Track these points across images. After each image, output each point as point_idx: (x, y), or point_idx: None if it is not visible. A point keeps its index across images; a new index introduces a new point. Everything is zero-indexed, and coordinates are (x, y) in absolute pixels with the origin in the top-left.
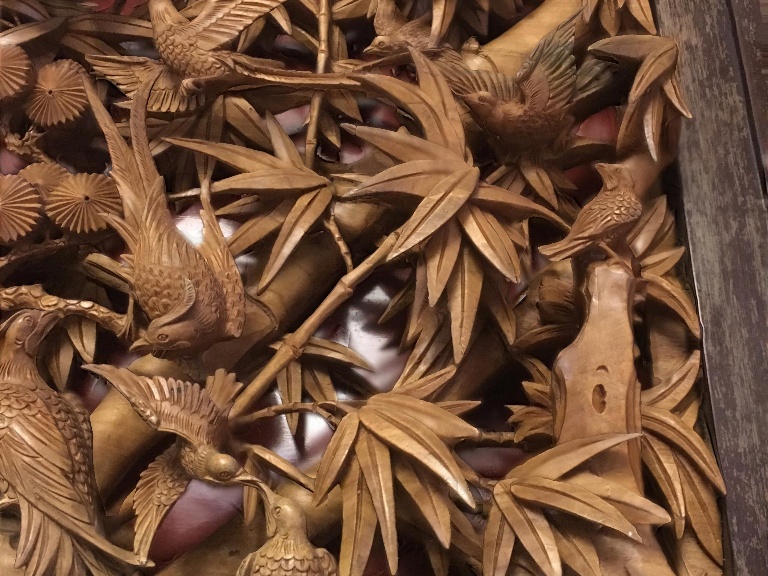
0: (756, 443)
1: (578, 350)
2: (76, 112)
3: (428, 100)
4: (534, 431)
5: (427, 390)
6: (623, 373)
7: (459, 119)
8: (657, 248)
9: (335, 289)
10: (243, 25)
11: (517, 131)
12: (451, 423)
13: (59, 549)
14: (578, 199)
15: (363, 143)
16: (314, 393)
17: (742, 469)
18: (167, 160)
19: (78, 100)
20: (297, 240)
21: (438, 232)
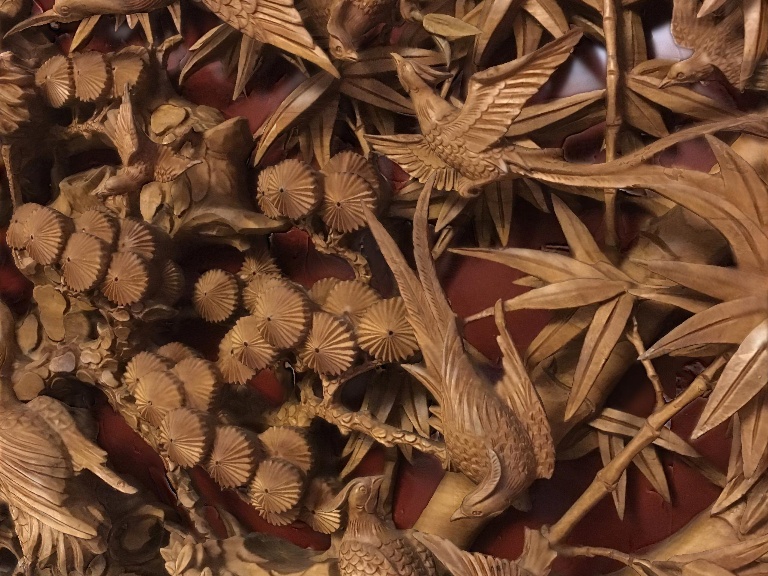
0: None
1: None
2: None
3: (734, 213)
4: None
5: (747, 559)
6: None
7: None
8: None
9: (642, 431)
10: (510, 117)
11: None
12: None
13: None
14: None
15: (674, 157)
16: (640, 466)
17: None
18: (463, 216)
19: None
20: (598, 369)
21: None
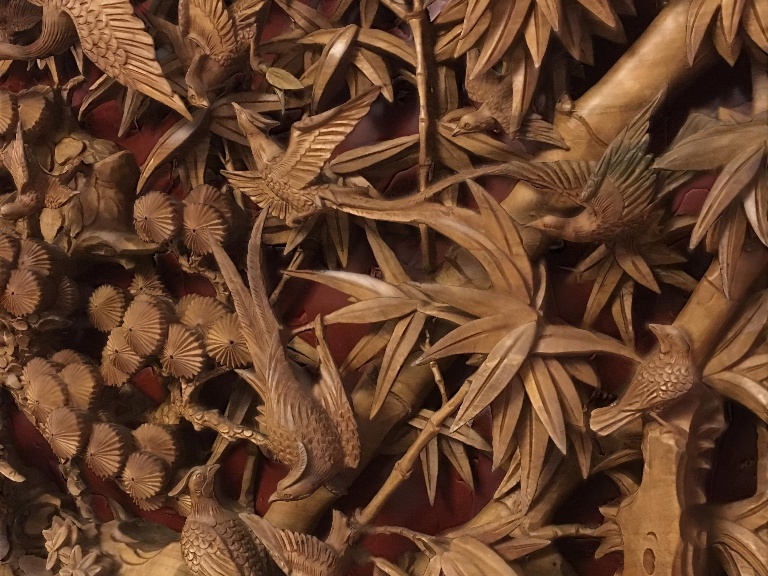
0: None
1: (632, 512)
2: None
3: (487, 245)
4: (614, 549)
5: (500, 534)
6: (670, 544)
7: (524, 253)
8: (763, 344)
9: (426, 427)
10: (323, 160)
11: (596, 240)
12: None
13: None
14: (689, 270)
15: None
16: (451, 459)
17: None
18: (310, 241)
19: (216, 233)
20: (394, 375)
21: (496, 398)
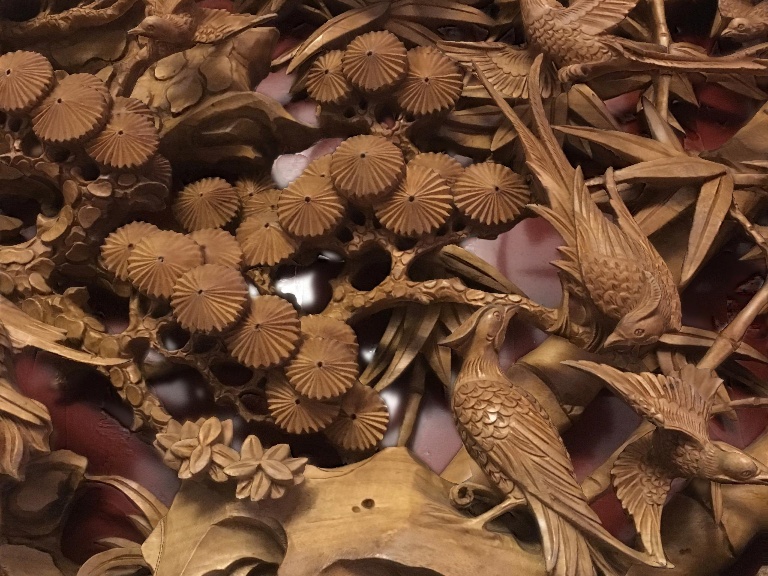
0: None
1: None
2: (451, 100)
3: None
4: None
5: None
6: None
7: None
8: None
9: None
10: (627, 8)
11: None
12: None
13: (578, 551)
14: None
15: (696, 129)
16: None
17: None
18: (511, 148)
19: (453, 88)
20: (716, 230)
21: None
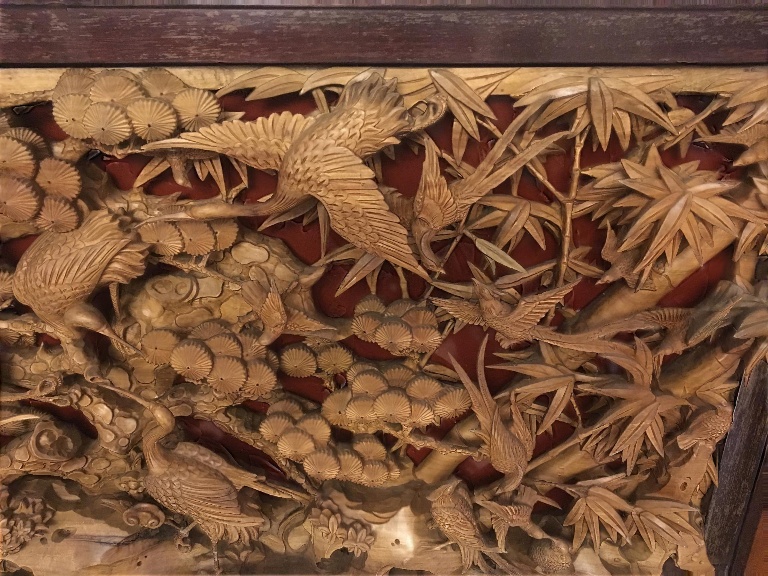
0: (737, 463)
1: (681, 470)
2: (435, 348)
3: (640, 369)
4: None
5: None
6: (697, 481)
7: (652, 367)
8: None
9: (575, 440)
10: (539, 318)
11: None
12: (624, 507)
13: None
14: None
15: None
16: None
17: (727, 472)
18: None
19: (436, 343)
20: (558, 416)
21: None
